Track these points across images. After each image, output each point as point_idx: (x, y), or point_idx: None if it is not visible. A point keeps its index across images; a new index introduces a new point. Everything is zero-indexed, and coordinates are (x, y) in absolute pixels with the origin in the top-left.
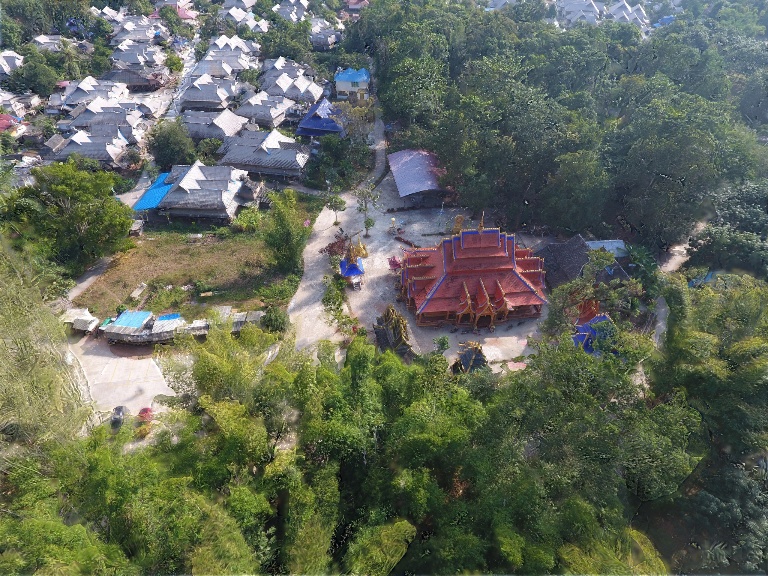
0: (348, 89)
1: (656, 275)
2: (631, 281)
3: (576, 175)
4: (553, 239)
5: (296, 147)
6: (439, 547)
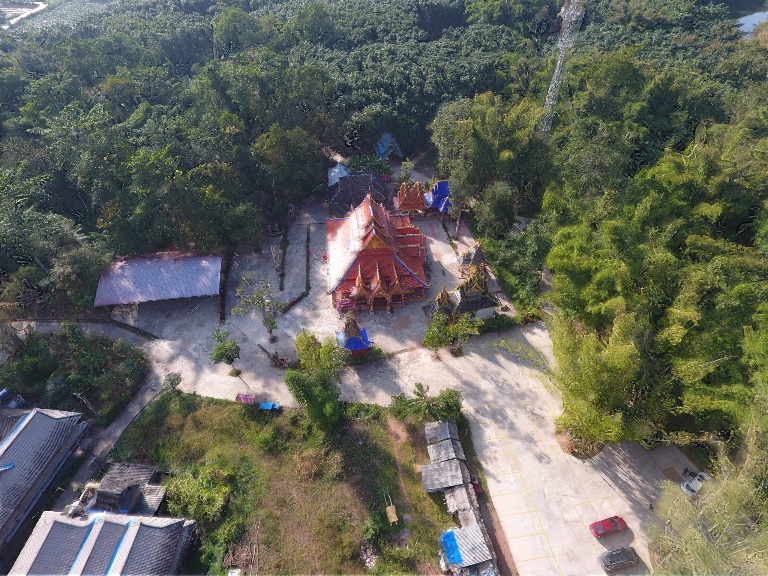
0: None
1: (379, 161)
2: (405, 164)
3: (293, 145)
4: (305, 207)
5: (1, 425)
6: (683, 237)
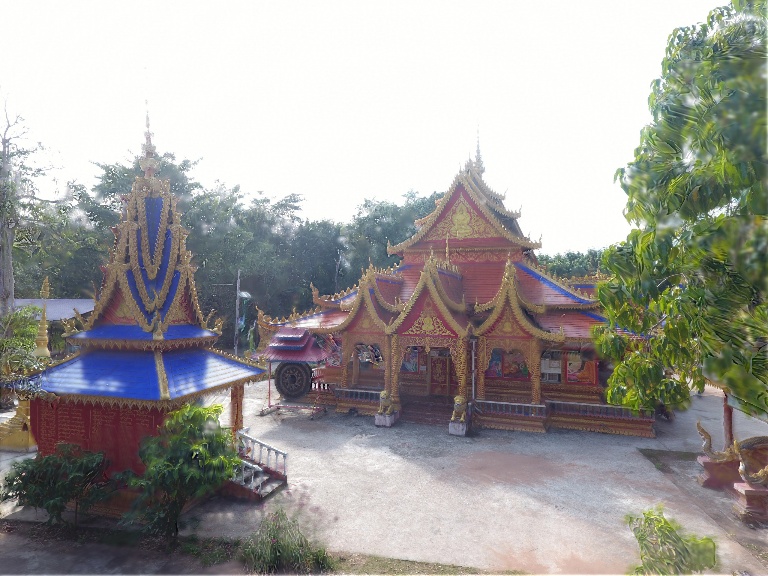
0: None
1: None
2: None
3: (396, 226)
4: None
5: None
6: None
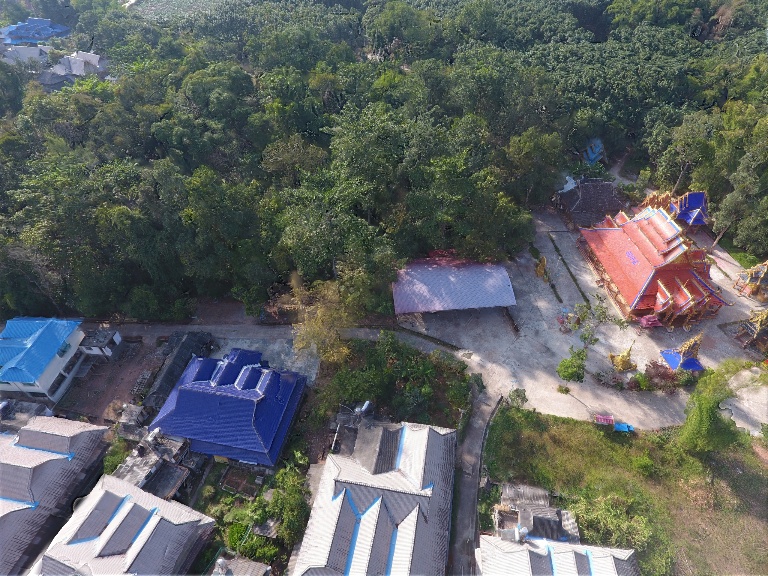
0: (59, 368)
1: None
2: None
3: None
4: (533, 213)
5: (389, 440)
6: None
